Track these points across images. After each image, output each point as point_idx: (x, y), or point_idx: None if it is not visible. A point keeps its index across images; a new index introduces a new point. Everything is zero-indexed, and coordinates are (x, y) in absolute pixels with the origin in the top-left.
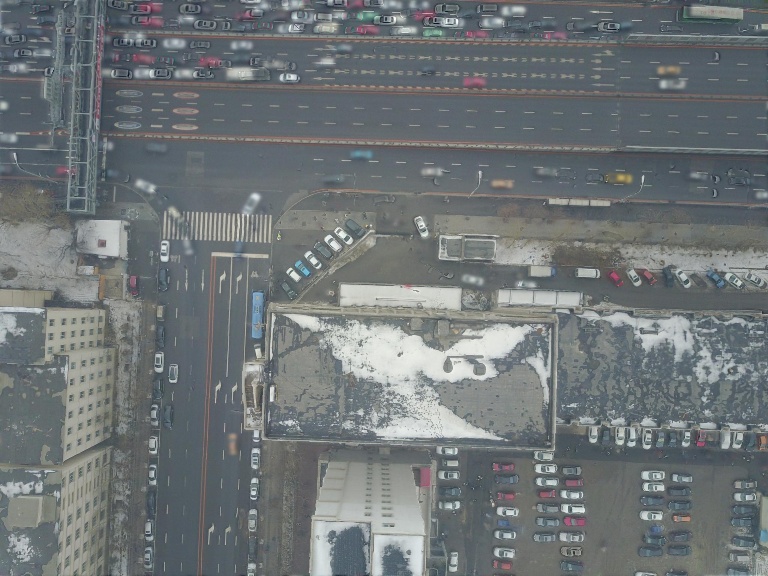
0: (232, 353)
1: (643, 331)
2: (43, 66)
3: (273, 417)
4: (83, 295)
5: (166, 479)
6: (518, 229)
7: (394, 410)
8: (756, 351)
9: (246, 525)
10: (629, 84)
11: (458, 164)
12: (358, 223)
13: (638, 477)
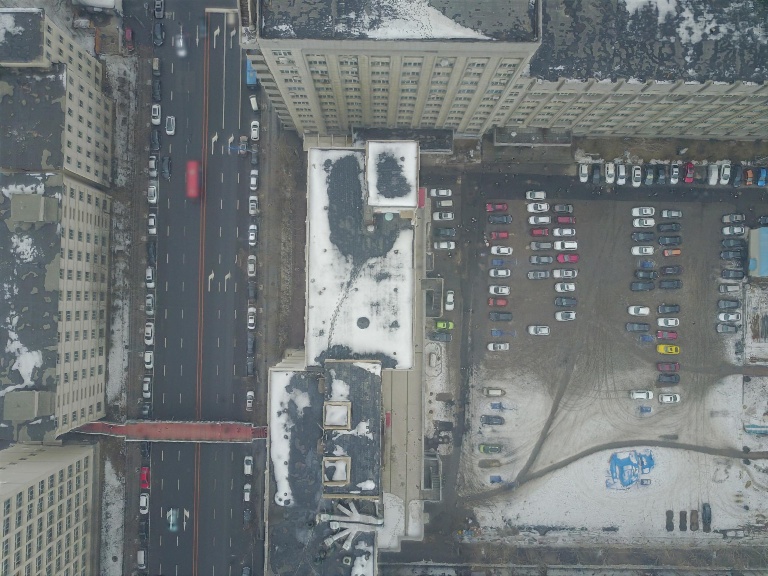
0: (228, 106)
1: None
2: None
3: (267, 22)
4: None
5: (166, 229)
6: None
7: (385, 12)
8: (737, 11)
9: (245, 270)
10: None
11: None
12: None
13: (629, 215)
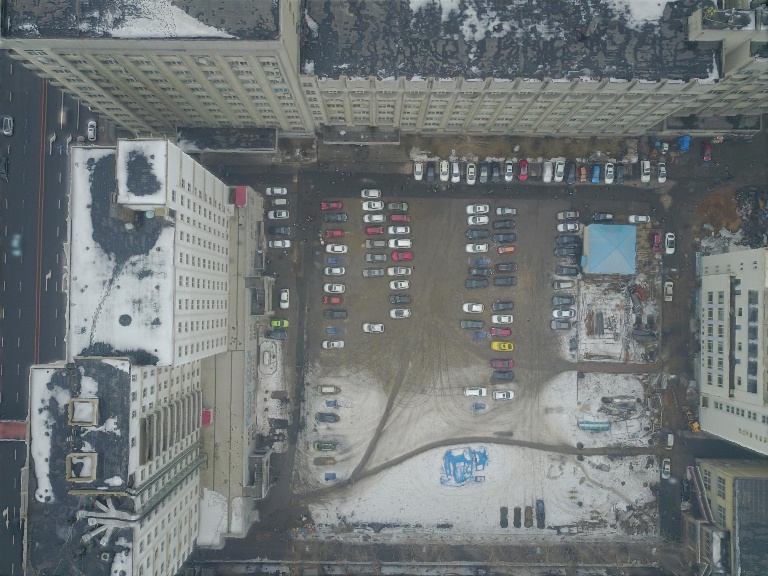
0: (66, 107)
1: None
2: None
3: (13, 22)
4: None
5: (3, 229)
6: None
7: (129, 11)
8: (520, 9)
9: None
10: None
11: None
12: None
13: (464, 213)
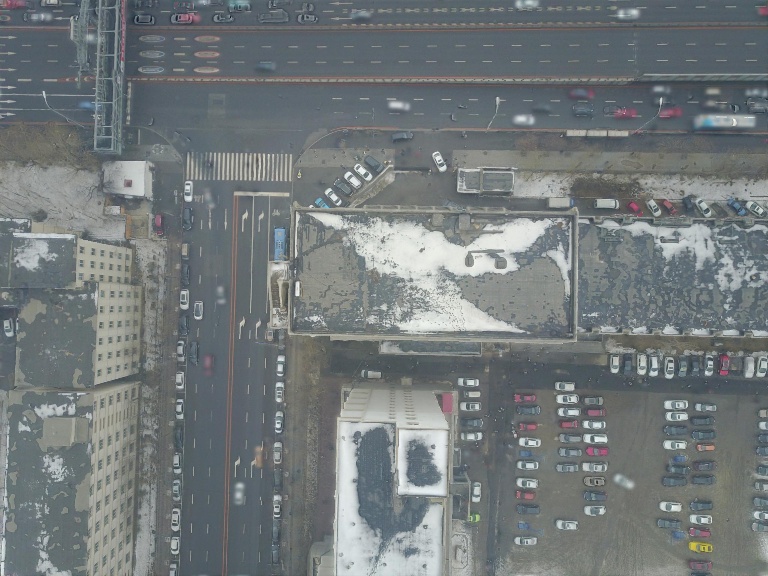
0: (255, 290)
1: (663, 239)
2: (69, 14)
3: (299, 313)
4: (110, 235)
5: (193, 414)
6: (536, 162)
7: (417, 304)
8: None
9: (271, 458)
10: (645, 14)
11: (475, 99)
12: (377, 159)
13: (661, 407)
